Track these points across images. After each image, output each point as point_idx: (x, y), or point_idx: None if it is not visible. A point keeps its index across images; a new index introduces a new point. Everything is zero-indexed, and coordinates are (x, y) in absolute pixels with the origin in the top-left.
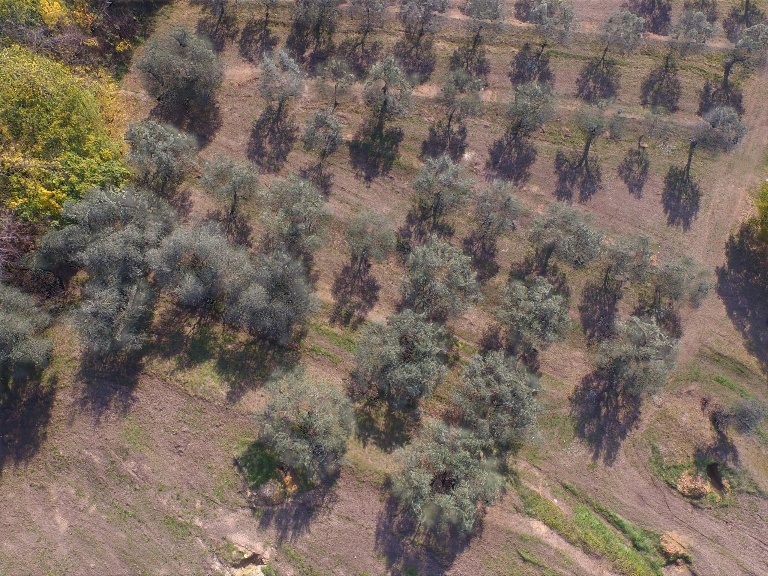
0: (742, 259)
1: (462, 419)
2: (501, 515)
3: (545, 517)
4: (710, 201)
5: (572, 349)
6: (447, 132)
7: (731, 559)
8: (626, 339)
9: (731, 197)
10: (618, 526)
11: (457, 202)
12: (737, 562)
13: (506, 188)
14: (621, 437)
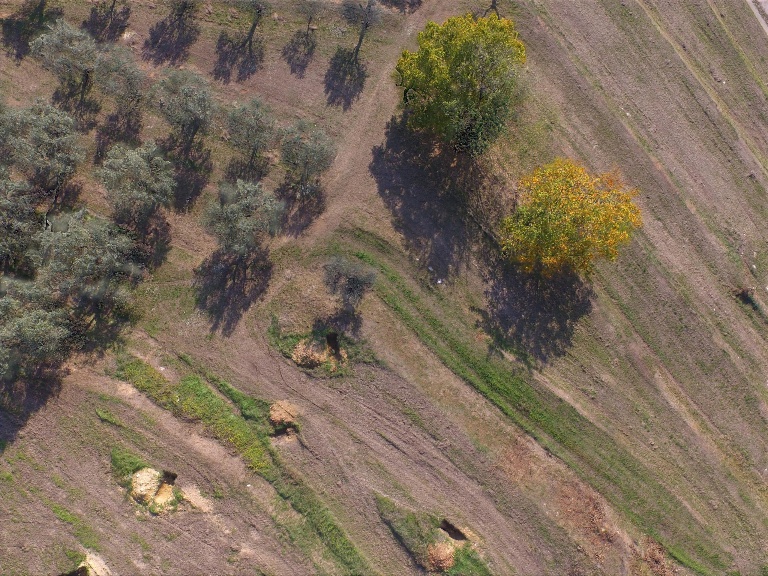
0: (402, 139)
1: (82, 290)
2: (86, 376)
3: (137, 380)
4: (376, 82)
5: (208, 223)
6: (110, 13)
7: (342, 428)
8: (264, 214)
9: (400, 79)
10: (229, 395)
11: (107, 79)
12: (348, 431)
13: (162, 67)
14: (244, 309)
